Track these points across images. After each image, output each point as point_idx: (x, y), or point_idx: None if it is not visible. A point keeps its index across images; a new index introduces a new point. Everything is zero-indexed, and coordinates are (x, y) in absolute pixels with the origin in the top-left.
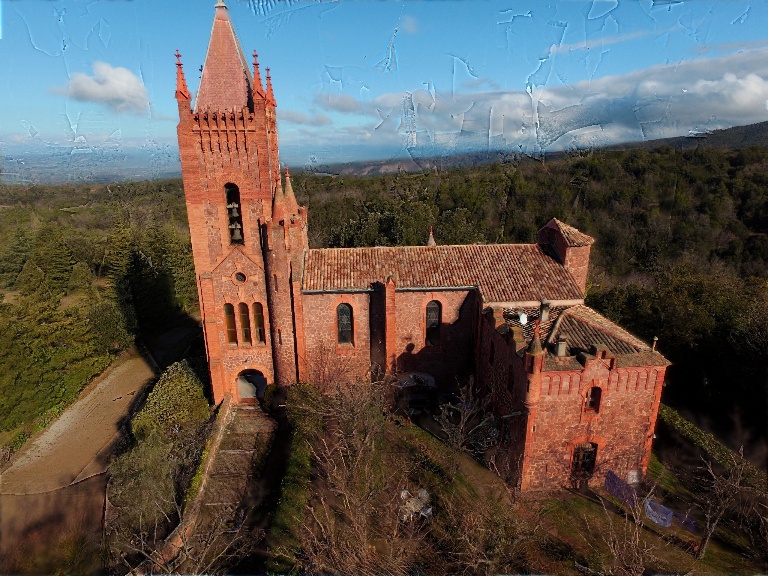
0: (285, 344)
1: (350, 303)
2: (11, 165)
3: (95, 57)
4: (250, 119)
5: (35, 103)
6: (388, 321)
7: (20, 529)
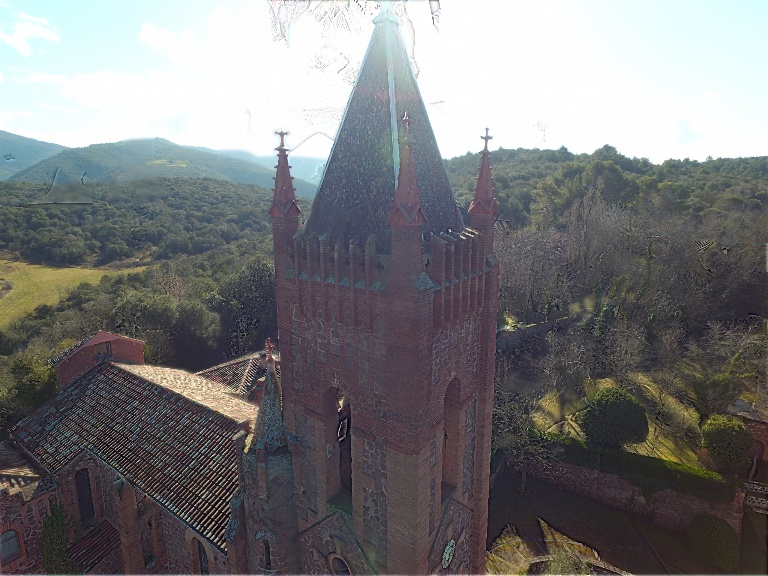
0: None
1: None
2: None
3: None
4: None
5: None
6: None
7: None
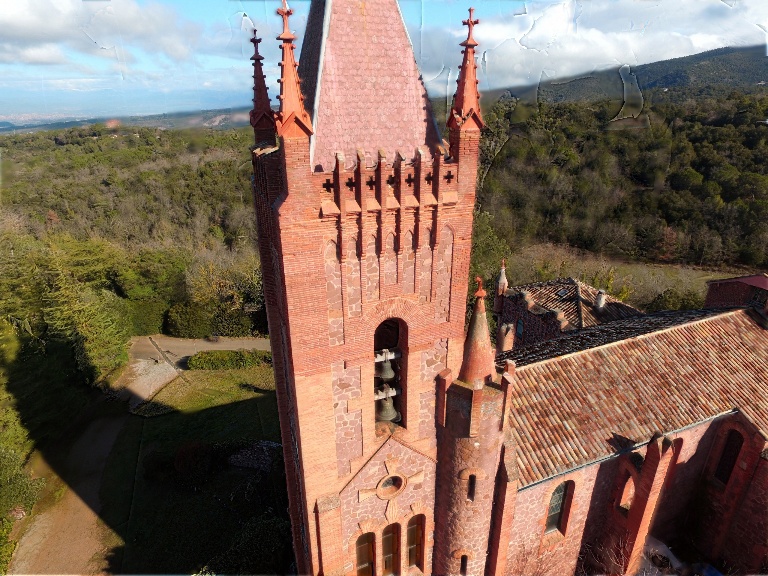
0: (472, 573)
1: (573, 479)
2: None
3: None
4: (446, 177)
5: None
6: (648, 504)
7: None
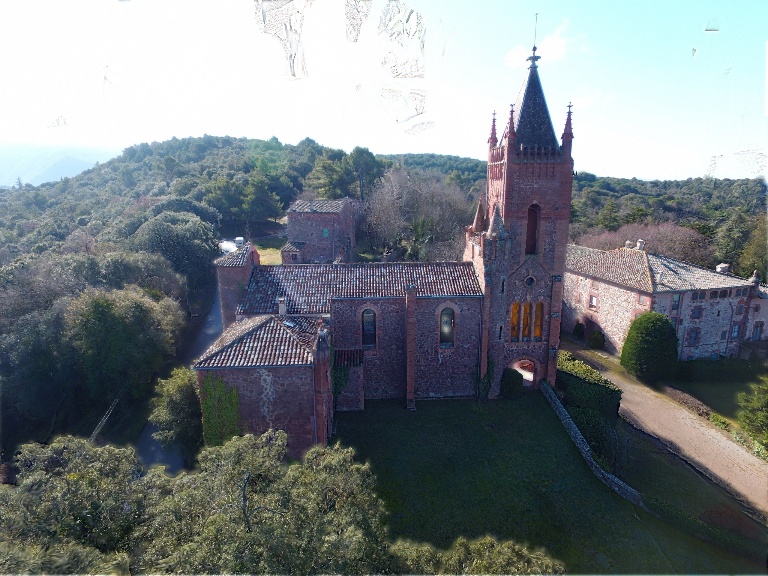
0: None
1: None
2: None
3: None
4: None
5: None
6: None
7: None
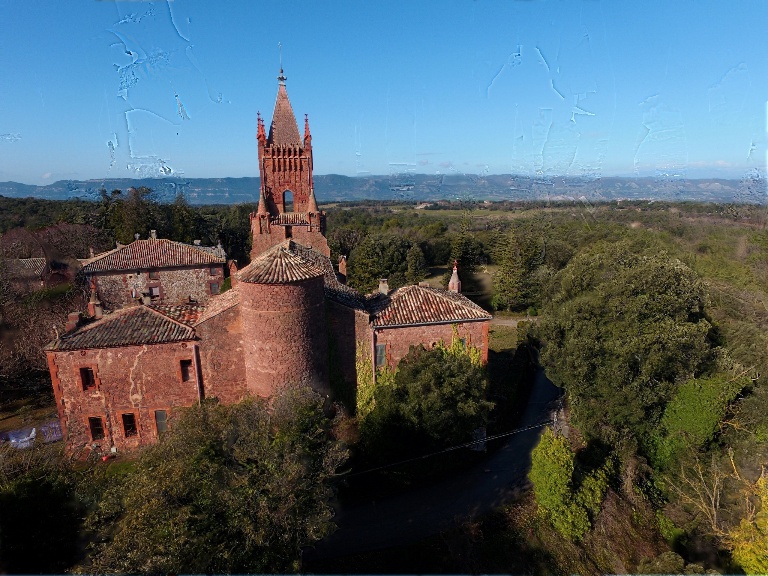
0: None
1: None
2: (525, 183)
3: (565, 92)
4: None
5: (587, 133)
6: None
7: (53, 255)
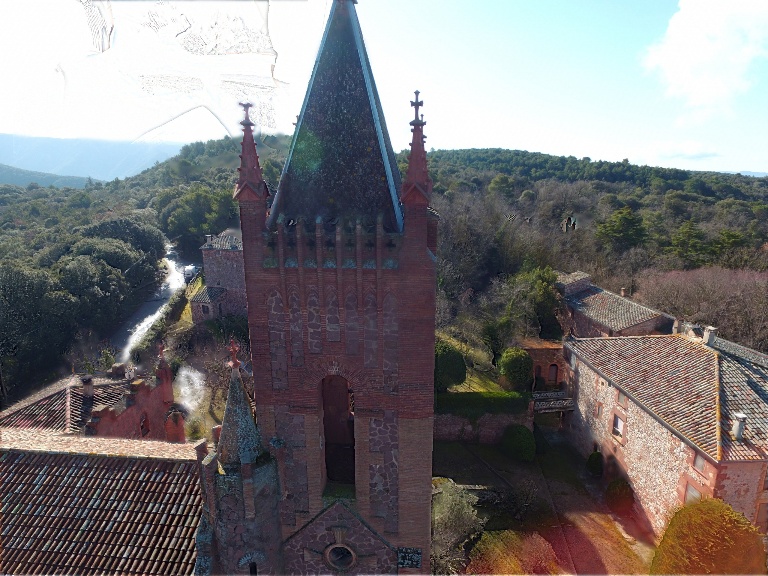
0: None
1: None
2: None
3: None
4: None
5: None
6: None
7: None
